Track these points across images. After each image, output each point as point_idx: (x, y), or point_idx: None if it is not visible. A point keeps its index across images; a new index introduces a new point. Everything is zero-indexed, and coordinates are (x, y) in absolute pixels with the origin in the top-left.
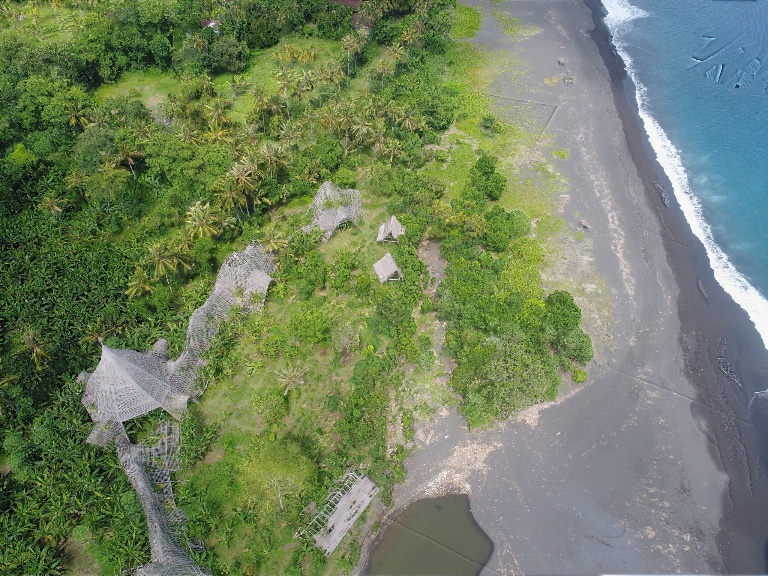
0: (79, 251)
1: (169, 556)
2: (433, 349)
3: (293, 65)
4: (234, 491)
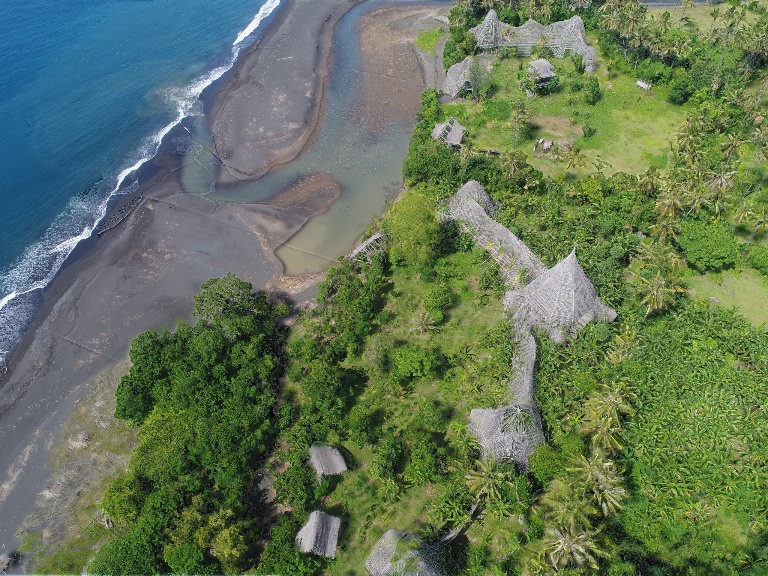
0: (765, 490)
1: (471, 205)
2: (288, 381)
3: None
4: (451, 265)
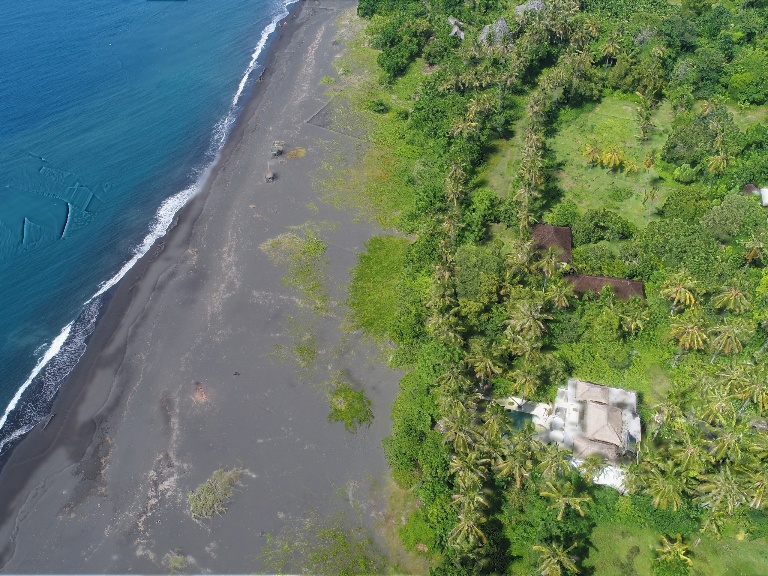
0: None
1: None
2: None
3: (611, 178)
4: None
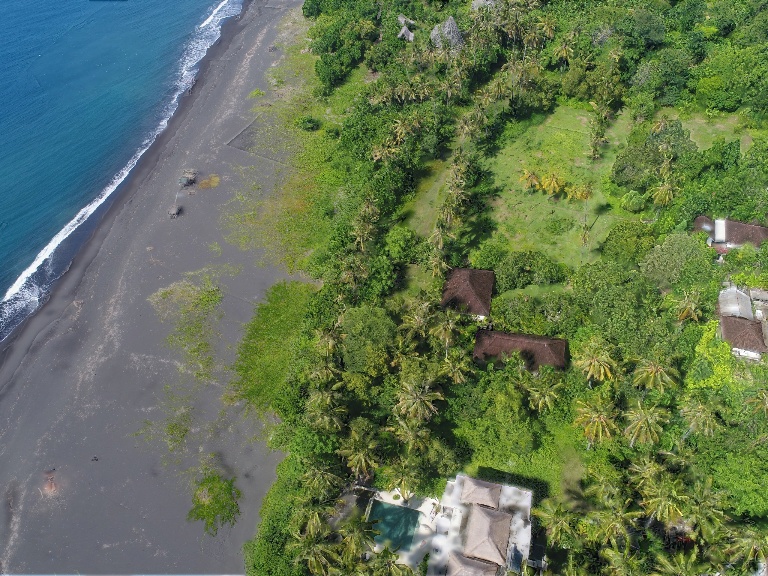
0: None
1: None
2: None
3: (552, 206)
4: None
